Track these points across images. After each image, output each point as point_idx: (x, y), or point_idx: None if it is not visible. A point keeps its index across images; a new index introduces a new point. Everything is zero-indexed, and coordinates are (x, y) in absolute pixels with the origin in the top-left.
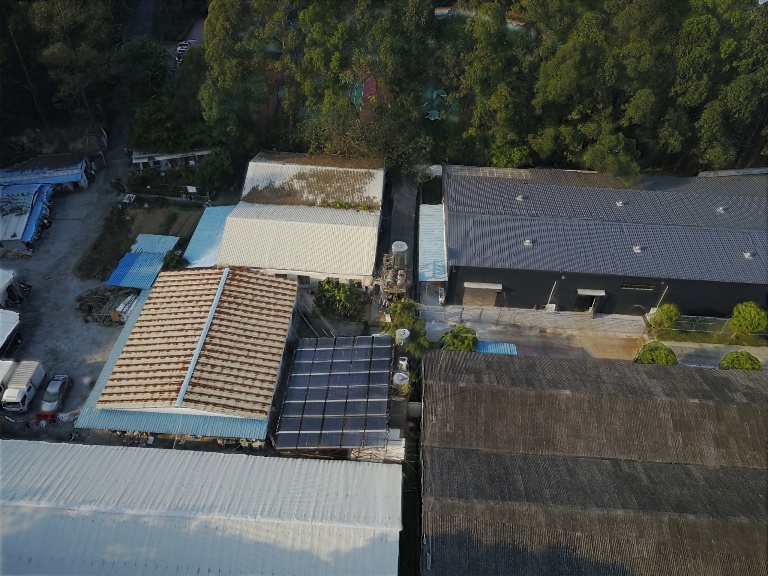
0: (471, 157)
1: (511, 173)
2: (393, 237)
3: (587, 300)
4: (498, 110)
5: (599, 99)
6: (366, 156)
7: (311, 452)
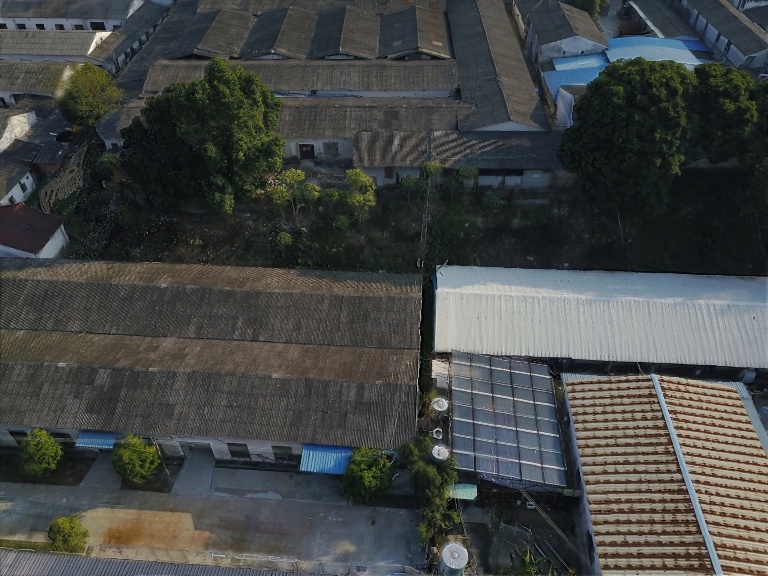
0: None
1: None
2: None
3: None
4: None
5: None
6: None
7: (515, 359)
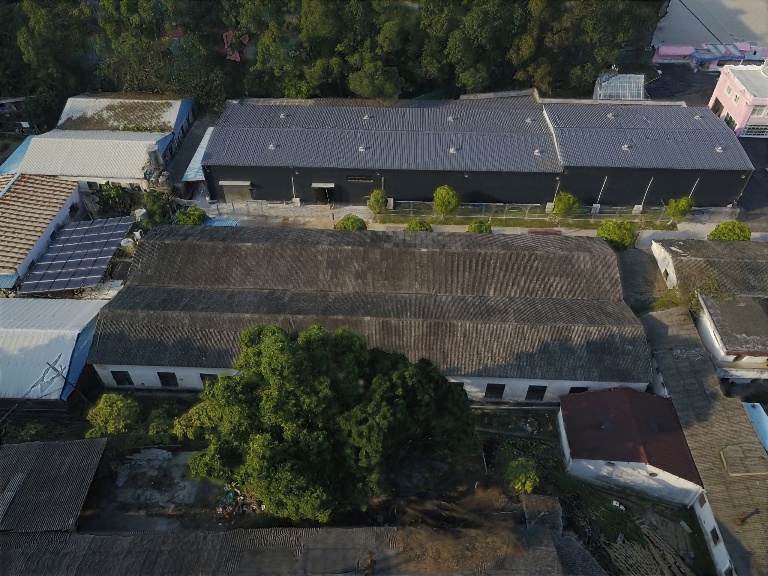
0: (272, 92)
1: (299, 102)
2: (179, 153)
3: (323, 193)
4: (270, 44)
5: (357, 32)
6: (177, 93)
7: (43, 294)
